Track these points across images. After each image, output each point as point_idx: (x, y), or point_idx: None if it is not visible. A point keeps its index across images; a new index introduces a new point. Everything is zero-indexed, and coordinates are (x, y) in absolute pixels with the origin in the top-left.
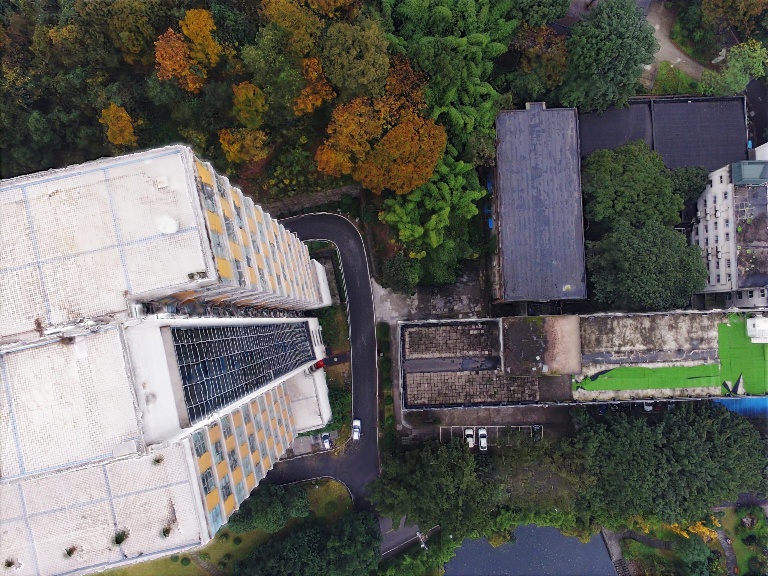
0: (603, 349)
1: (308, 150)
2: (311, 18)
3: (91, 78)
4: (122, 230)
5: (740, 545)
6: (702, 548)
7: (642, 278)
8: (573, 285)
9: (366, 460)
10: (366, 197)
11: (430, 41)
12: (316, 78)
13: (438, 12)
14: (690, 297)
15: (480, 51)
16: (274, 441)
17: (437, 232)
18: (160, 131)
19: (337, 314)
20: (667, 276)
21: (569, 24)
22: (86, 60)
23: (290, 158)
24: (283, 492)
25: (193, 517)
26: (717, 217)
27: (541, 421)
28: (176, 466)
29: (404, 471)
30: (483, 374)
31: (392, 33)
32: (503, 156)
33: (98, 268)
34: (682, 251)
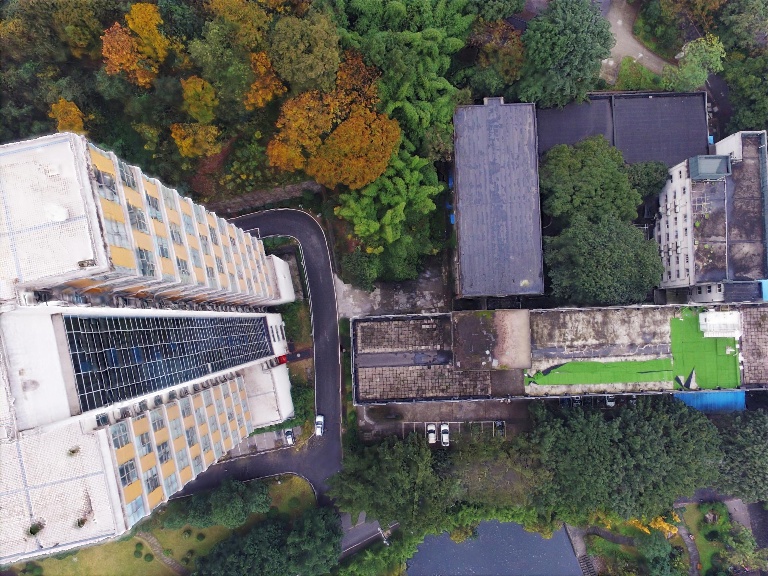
0: (555, 343)
1: (264, 145)
2: (257, 12)
3: (42, 73)
4: (13, 218)
5: (703, 541)
6: (663, 544)
7: (597, 273)
8: (530, 280)
9: (329, 456)
10: (327, 193)
11: (384, 36)
12: (265, 72)
13: (392, 7)
14: (647, 292)
15: (435, 46)
16: (221, 435)
17: (394, 227)
18: (116, 126)
19: (300, 310)
20: (622, 271)
21: (529, 19)
22: (34, 54)
23: (246, 153)
24: (244, 488)
25: (109, 508)
26: (677, 212)
27: (504, 417)
28: (92, 457)
29: (362, 466)
30: (435, 369)
31: (347, 28)
32: (461, 151)
33: None
34: (638, 246)
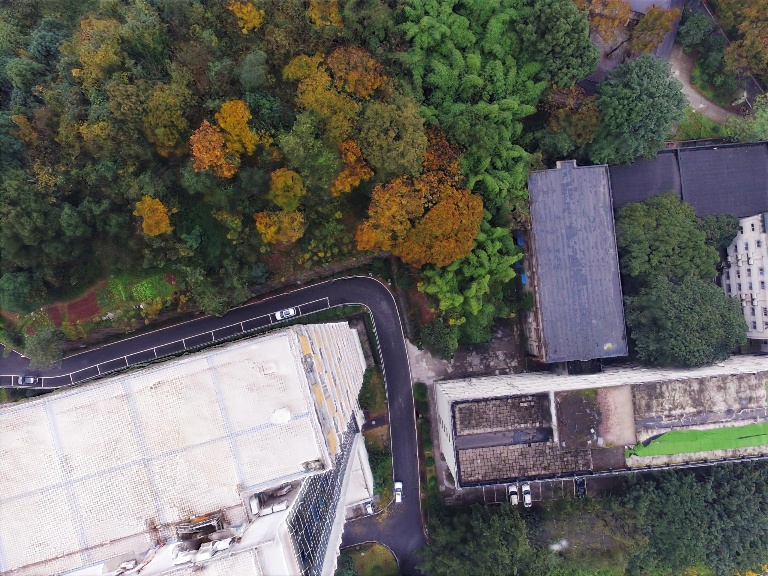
0: (653, 414)
1: (342, 222)
2: (349, 104)
3: (122, 169)
4: (229, 420)
5: None
6: None
7: (685, 337)
8: (614, 343)
9: (409, 522)
10: (398, 260)
11: (462, 110)
12: (355, 161)
13: (469, 81)
14: None
15: (511, 115)
16: None
17: (476, 298)
18: (190, 212)
19: (372, 376)
20: (710, 333)
21: (592, 77)
22: (118, 154)
23: (325, 233)
24: None
25: None
26: (750, 264)
27: None
28: None
29: (454, 539)
30: (535, 446)
31: (422, 102)
32: (537, 216)
33: (207, 462)
34: (722, 306)
